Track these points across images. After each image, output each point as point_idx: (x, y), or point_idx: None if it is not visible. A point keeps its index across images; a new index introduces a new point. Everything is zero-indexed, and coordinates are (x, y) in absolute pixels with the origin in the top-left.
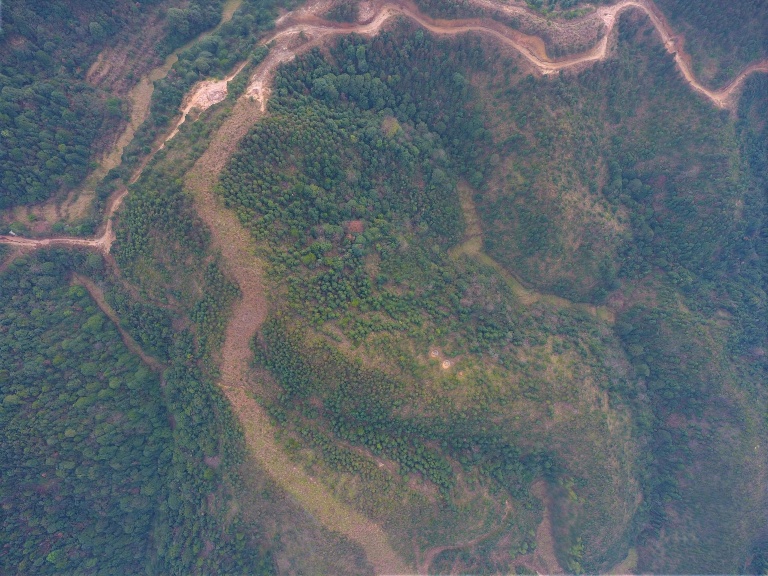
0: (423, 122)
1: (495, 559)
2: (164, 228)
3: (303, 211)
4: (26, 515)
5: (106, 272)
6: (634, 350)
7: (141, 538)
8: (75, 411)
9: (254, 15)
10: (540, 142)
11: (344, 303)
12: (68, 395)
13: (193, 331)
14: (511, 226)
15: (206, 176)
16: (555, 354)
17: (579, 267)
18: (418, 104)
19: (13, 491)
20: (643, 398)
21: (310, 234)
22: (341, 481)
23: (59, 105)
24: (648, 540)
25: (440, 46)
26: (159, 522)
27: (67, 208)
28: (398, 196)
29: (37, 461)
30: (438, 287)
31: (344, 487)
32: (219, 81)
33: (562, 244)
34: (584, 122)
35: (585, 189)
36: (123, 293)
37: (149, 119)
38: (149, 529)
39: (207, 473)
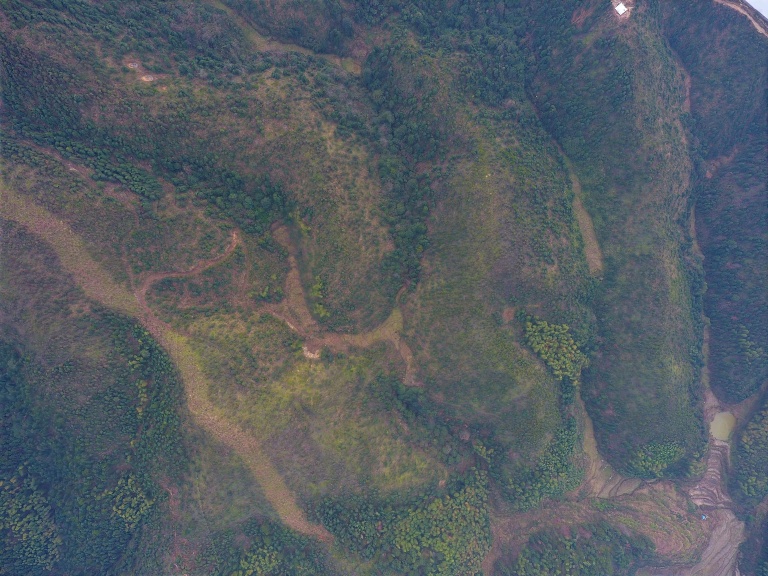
0: None
1: (236, 303)
2: None
3: None
4: None
5: None
6: (375, 95)
7: None
8: None
9: None
10: None
11: None
12: None
13: None
14: None
15: None
16: (272, 79)
17: (307, 4)
18: None
19: None
20: (387, 145)
21: None
22: (16, 171)
23: None
24: (408, 296)
25: None
26: None
27: None
28: None
29: None
30: (150, 14)
31: (17, 175)
32: None
33: None
34: None
35: None
36: None
37: None
38: None
39: None
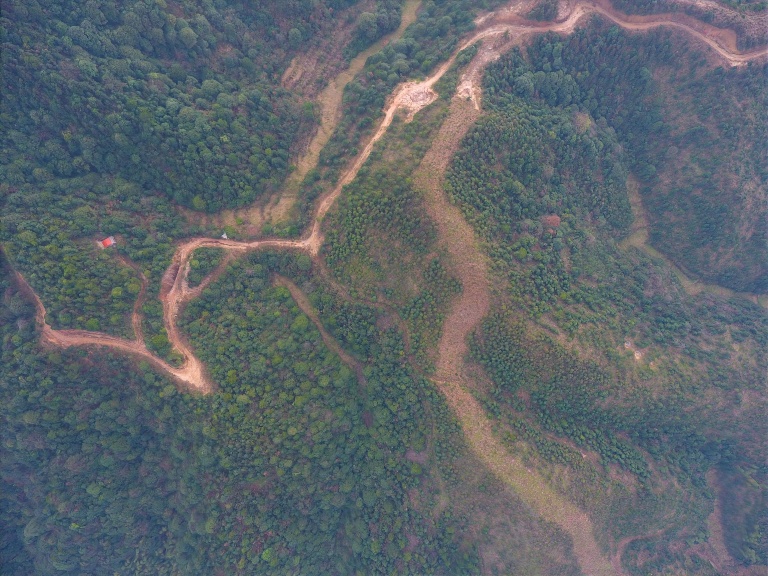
0: (603, 117)
1: (672, 549)
2: (387, 227)
3: (510, 207)
4: (243, 514)
5: (313, 272)
6: None
7: (332, 536)
8: (295, 410)
9: (451, 17)
10: (725, 133)
11: (554, 296)
12: (286, 394)
13: (402, 328)
14: (685, 217)
15: (434, 174)
16: (736, 342)
17: (748, 256)
18: (600, 99)
19: (233, 490)
20: None
21: (514, 229)
22: (555, 472)
23: (265, 110)
24: None
25: (632, 42)
26: (351, 519)
27: (270, 211)
28: (581, 191)
29: (263, 460)
30: (619, 279)
31: (560, 478)
32: (421, 82)
33: (737, 234)
34: (765, 112)
35: (757, 179)
36: (331, 293)
37: (345, 122)
38: (338, 527)
39: (416, 468)
